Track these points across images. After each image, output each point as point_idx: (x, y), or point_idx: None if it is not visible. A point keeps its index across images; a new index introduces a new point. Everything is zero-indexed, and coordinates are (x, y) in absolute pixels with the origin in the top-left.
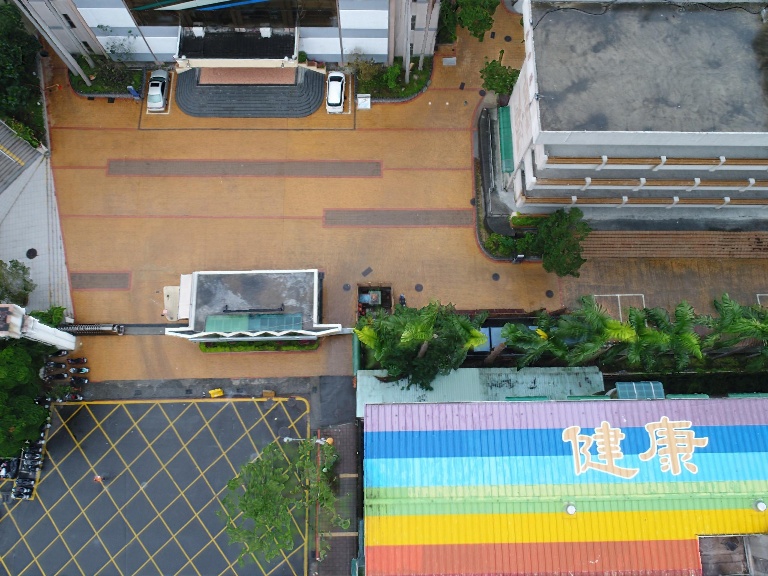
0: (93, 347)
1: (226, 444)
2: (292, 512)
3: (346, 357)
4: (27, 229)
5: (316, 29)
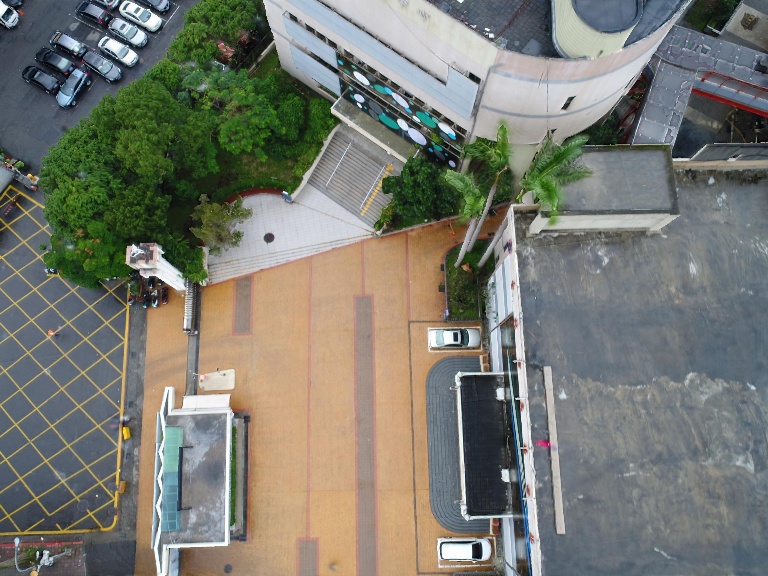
0: (179, 307)
1: (77, 447)
2: (8, 519)
3: (153, 570)
4: (295, 229)
5: (514, 540)
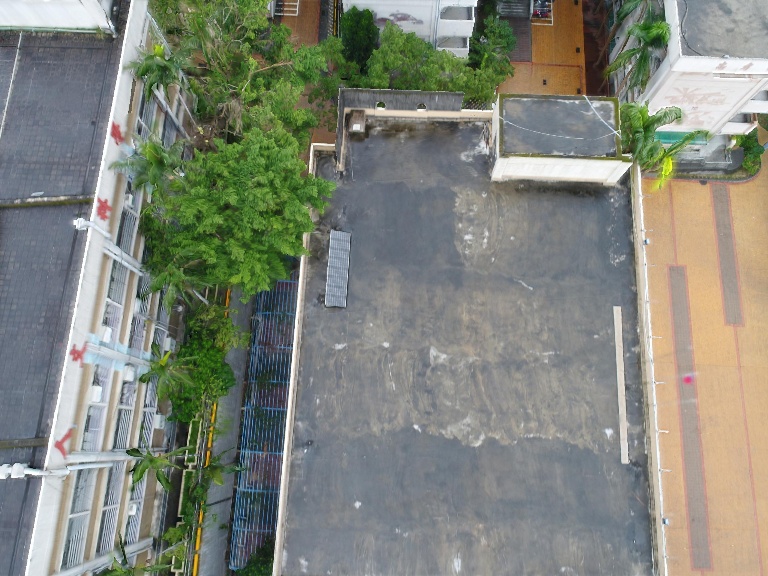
0: None
1: None
2: None
3: None
4: None
5: None
